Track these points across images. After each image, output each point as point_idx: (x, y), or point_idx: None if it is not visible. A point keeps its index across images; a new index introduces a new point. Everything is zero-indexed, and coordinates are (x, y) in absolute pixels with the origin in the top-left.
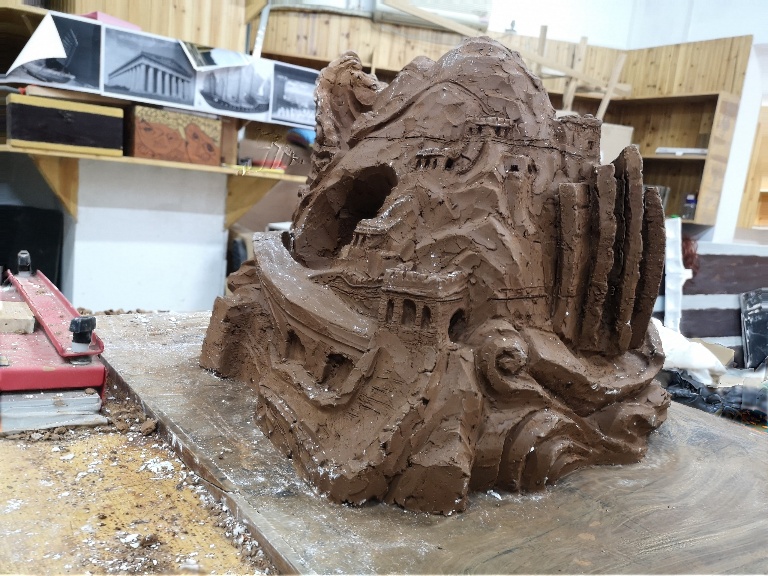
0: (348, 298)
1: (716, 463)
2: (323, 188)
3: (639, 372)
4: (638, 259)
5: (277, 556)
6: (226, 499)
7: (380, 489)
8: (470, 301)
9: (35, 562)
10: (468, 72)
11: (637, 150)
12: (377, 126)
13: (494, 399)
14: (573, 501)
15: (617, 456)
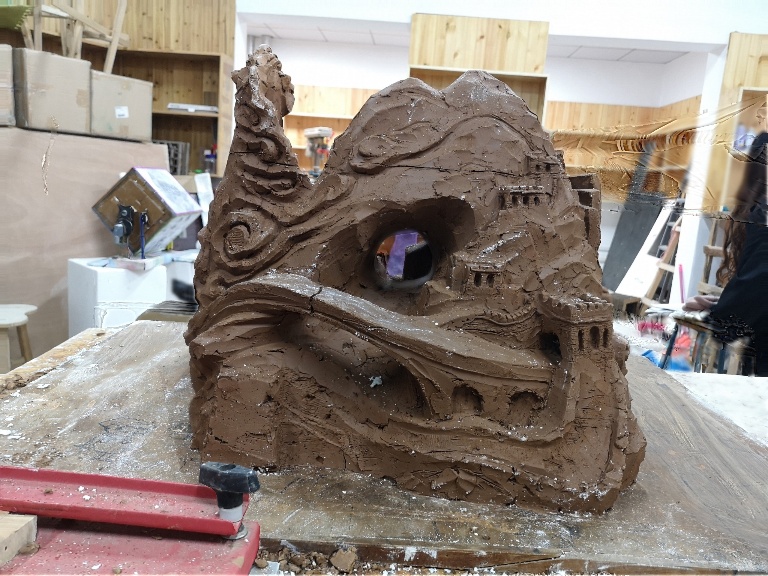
0: (495, 337)
1: None
2: (352, 221)
3: None
4: None
5: (665, 571)
6: (562, 564)
7: None
8: None
9: None
10: (508, 110)
11: None
12: (413, 154)
13: None
14: None
15: None
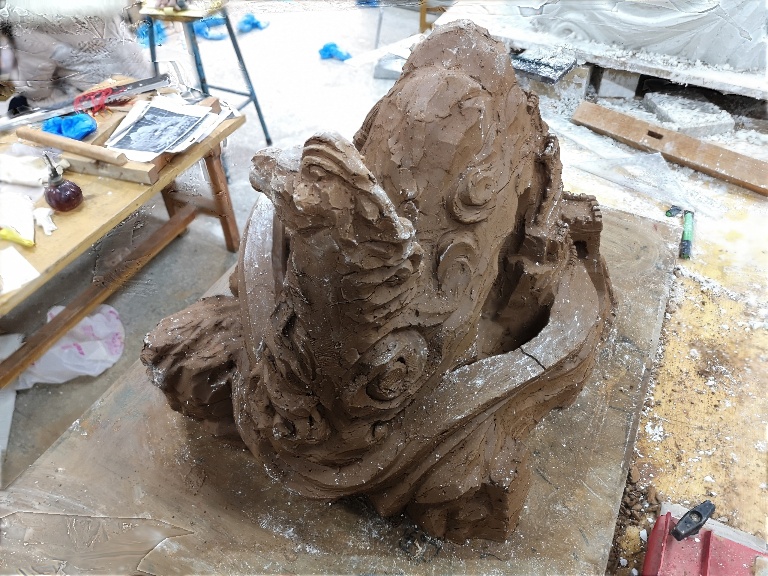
0: None
1: None
2: None
3: None
4: None
5: None
6: None
7: None
8: None
9: (761, 396)
10: None
11: None
12: None
13: None
14: None
15: None
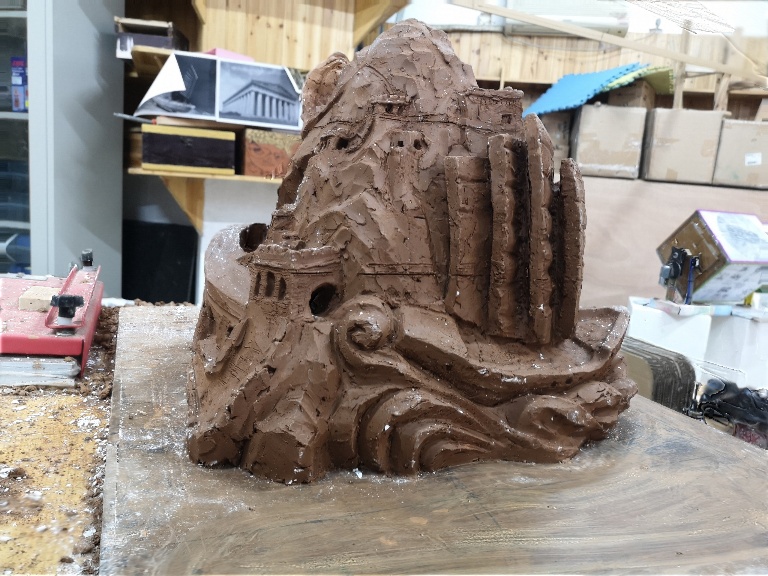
0: None
1: (661, 473)
2: None
3: (574, 365)
4: (542, 236)
5: None
6: None
7: (231, 452)
8: (344, 277)
9: None
10: (380, 54)
11: (536, 118)
12: (319, 117)
13: (352, 374)
14: (439, 488)
15: (527, 452)
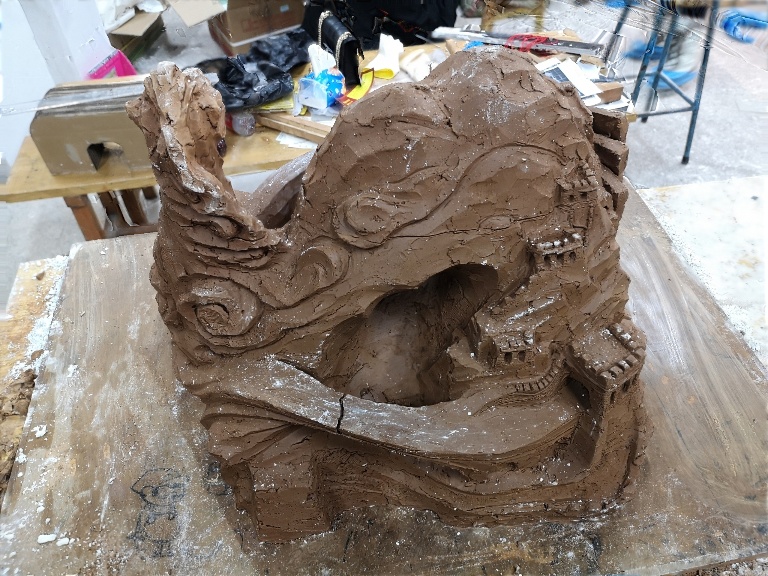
0: (526, 402)
1: None
2: (357, 312)
3: None
4: None
5: None
6: None
7: None
8: None
9: None
10: (536, 127)
11: None
12: (419, 219)
13: None
14: None
15: None
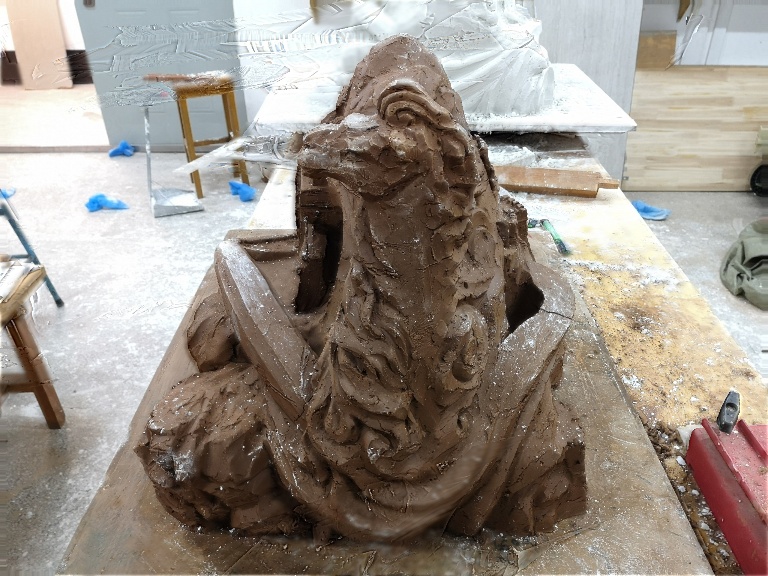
0: None
1: None
2: None
3: None
4: None
5: None
6: None
7: None
8: None
9: None
10: None
11: None
12: None
13: None
14: None
15: None
